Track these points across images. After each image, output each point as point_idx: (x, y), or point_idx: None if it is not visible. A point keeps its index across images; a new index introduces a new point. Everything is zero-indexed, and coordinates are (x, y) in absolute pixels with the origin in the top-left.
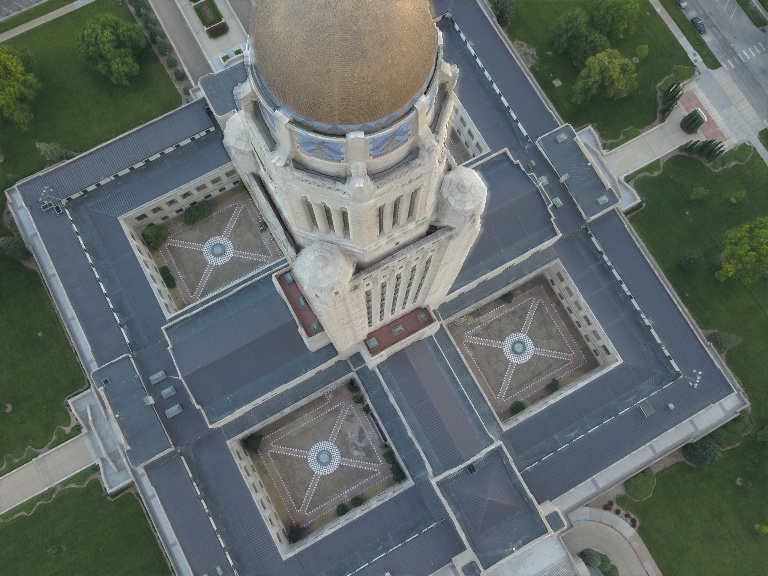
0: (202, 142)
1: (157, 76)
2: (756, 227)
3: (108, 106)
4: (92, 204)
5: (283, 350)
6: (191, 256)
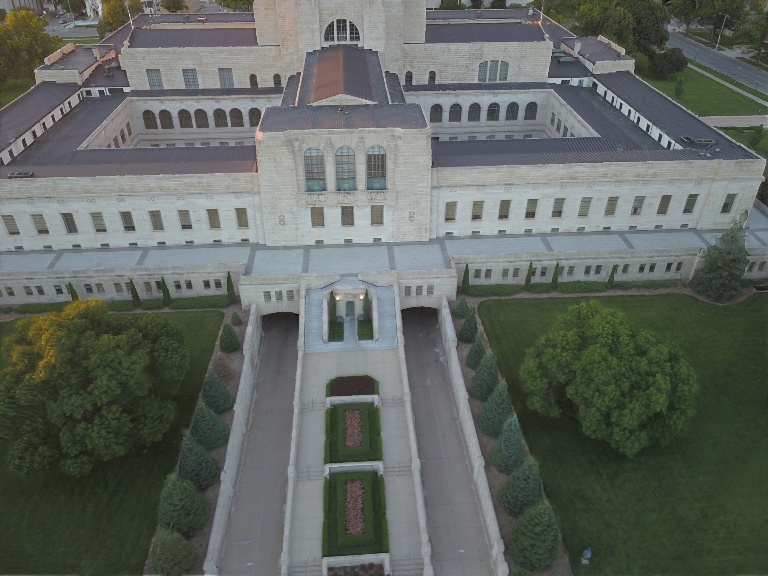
0: None
1: (517, 356)
2: (6, 35)
3: None
4: None
5: None
6: None
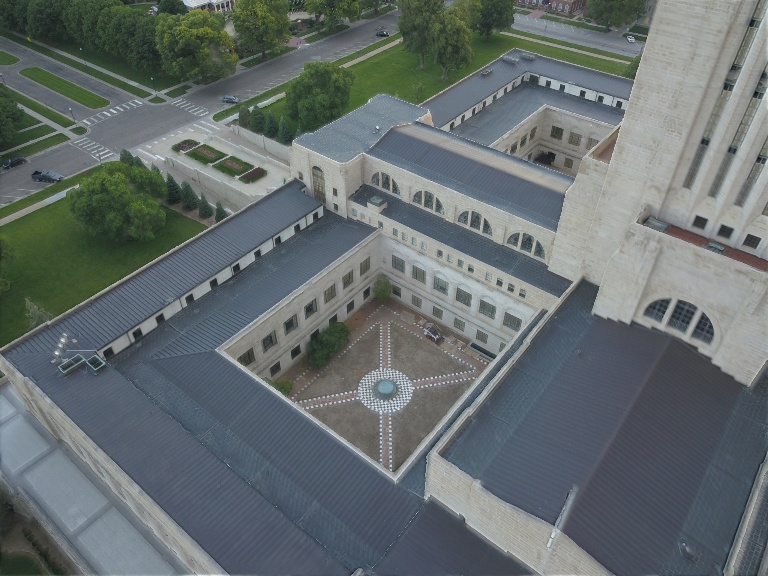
0: (310, 233)
1: (189, 230)
2: None
3: (123, 276)
4: (155, 350)
5: (699, 400)
6: (343, 414)
